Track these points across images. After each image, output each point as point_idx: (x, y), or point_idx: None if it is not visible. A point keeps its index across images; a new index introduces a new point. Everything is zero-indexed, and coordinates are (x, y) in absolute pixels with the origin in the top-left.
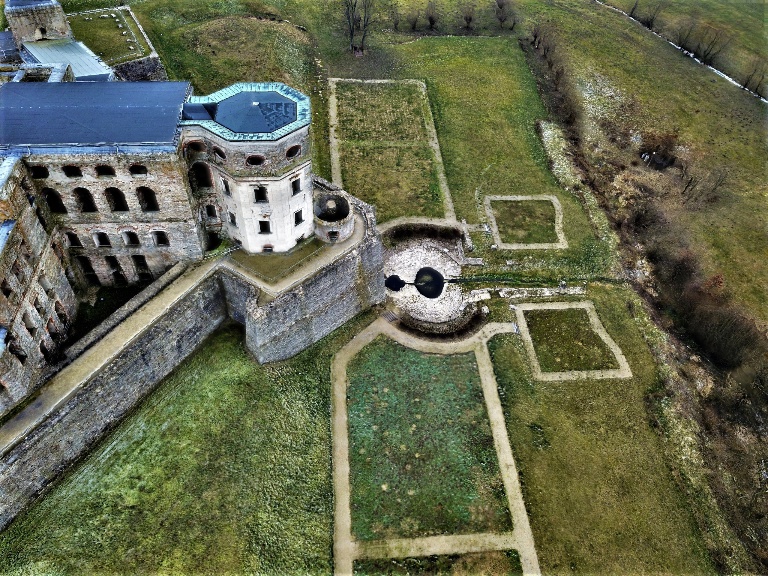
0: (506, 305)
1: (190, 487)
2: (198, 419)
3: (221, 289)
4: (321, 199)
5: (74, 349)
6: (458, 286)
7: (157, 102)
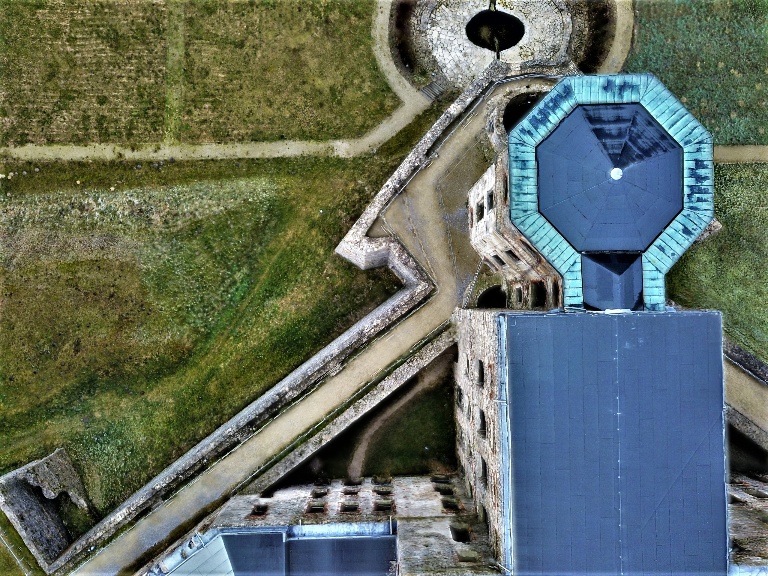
0: None
1: None
2: None
3: None
4: None
5: (767, 443)
6: None
7: (601, 363)
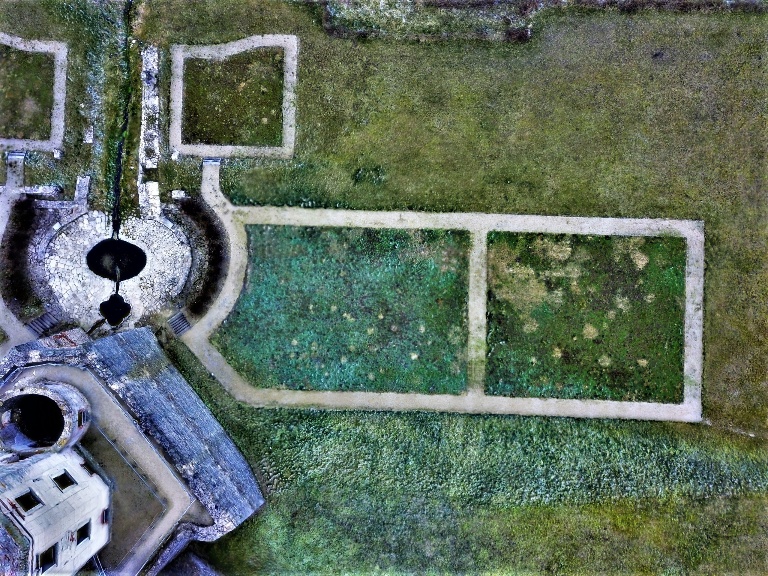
0: (172, 165)
1: (419, 570)
2: (339, 571)
3: (165, 572)
4: (2, 437)
5: None
6: (127, 221)
7: None
